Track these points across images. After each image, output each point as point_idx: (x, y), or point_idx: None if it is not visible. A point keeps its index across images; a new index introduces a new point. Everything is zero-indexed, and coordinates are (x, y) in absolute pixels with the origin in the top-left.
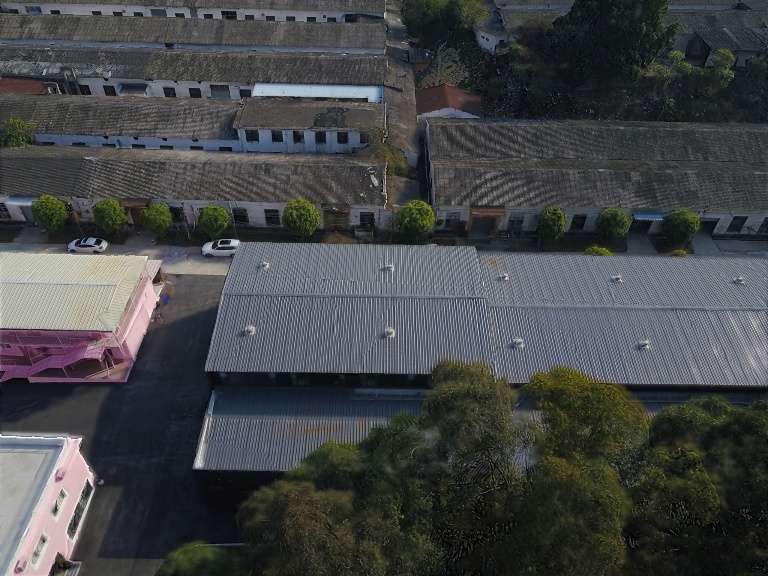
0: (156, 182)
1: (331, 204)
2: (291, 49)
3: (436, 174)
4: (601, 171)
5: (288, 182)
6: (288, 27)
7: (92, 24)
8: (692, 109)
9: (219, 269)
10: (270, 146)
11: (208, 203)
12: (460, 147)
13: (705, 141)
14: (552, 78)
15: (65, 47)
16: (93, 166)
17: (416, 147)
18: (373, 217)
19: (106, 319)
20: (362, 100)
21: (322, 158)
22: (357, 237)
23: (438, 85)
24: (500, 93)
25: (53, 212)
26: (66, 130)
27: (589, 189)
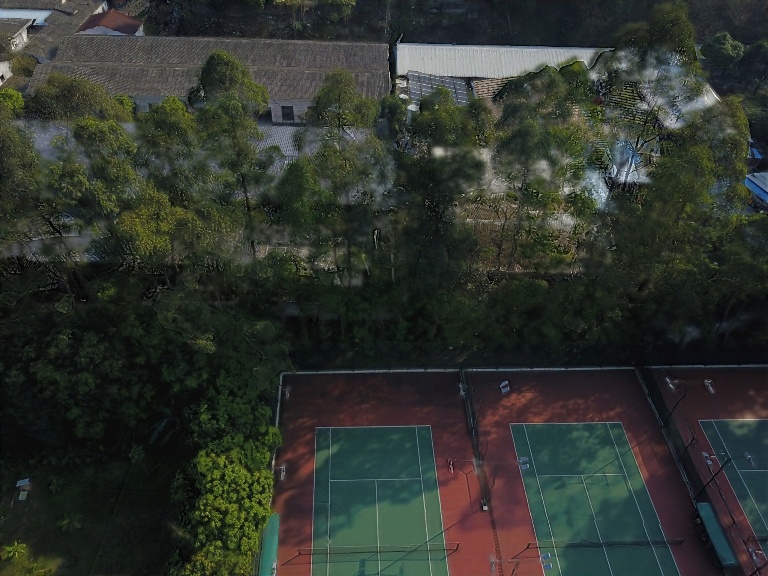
0: None
1: None
2: None
3: (36, 70)
4: (177, 69)
5: None
6: None
7: None
8: (324, 32)
9: None
10: None
11: None
12: (83, 54)
13: (295, 51)
14: (207, 5)
15: None
16: None
17: (50, 55)
18: None
19: None
20: (33, 21)
21: None
22: None
23: None
24: (166, 19)
25: None
26: None
27: (160, 82)
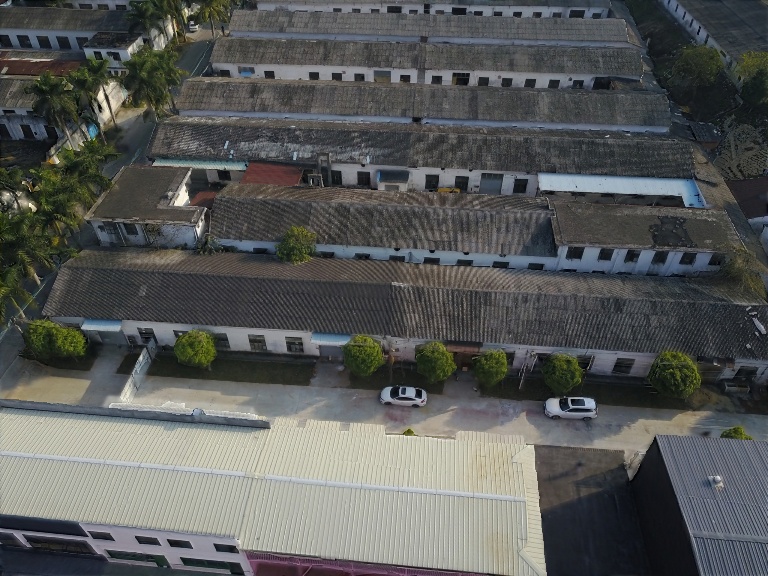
0: (484, 319)
1: (710, 357)
2: (558, 125)
3: None
4: None
5: (649, 325)
6: (551, 98)
7: (329, 94)
8: None
9: (574, 438)
10: (592, 264)
11: (552, 349)
12: None
13: None
14: None
15: (308, 123)
16: (405, 295)
17: None
18: (755, 372)
19: (531, 558)
20: (672, 197)
21: (672, 287)
22: (728, 394)
23: (758, 178)
24: None
25: (372, 359)
26: (351, 240)
27: None
